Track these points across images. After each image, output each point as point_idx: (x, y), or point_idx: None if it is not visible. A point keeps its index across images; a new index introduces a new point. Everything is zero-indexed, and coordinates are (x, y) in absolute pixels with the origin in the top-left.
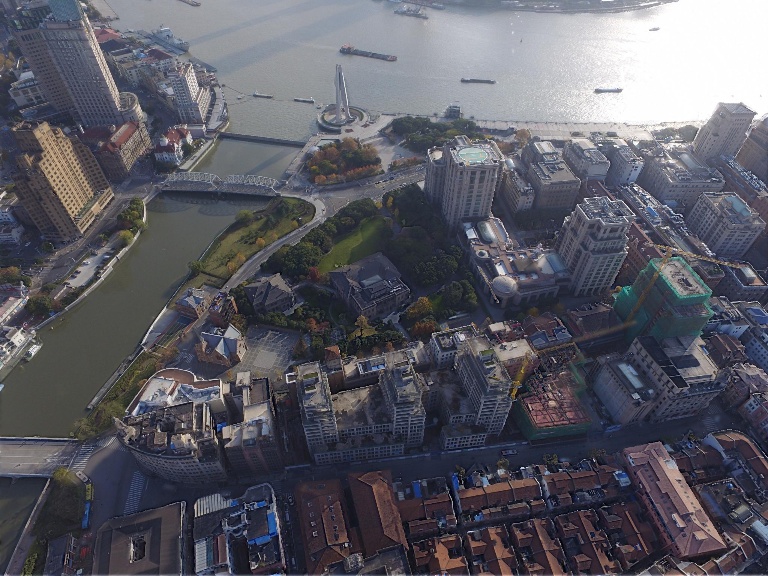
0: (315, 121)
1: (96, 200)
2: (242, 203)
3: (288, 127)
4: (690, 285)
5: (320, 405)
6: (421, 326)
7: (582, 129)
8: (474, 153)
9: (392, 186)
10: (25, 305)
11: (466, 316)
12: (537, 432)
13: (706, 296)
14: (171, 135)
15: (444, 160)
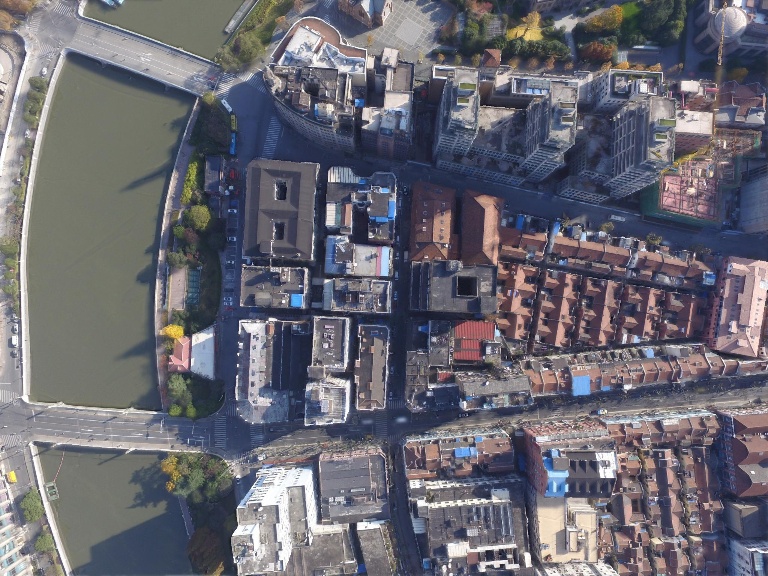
0: None
1: None
2: None
3: None
4: None
5: (467, 121)
6: (598, 48)
7: None
8: None
9: None
10: None
11: (655, 50)
12: (657, 212)
13: None
14: None
15: None
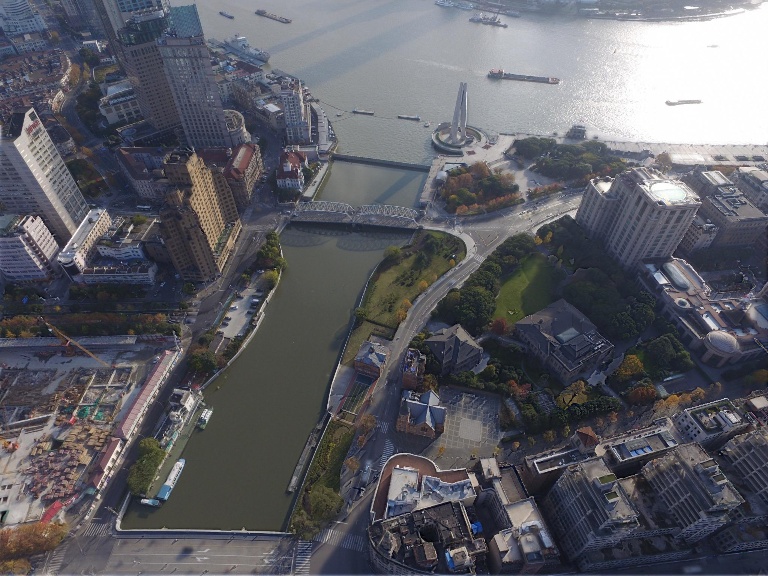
0: (430, 141)
1: (229, 234)
2: (376, 235)
3: (403, 148)
4: None
5: None
6: (644, 392)
7: (722, 152)
8: (669, 189)
9: (539, 217)
10: (188, 361)
11: (681, 377)
12: None
13: None
14: (291, 159)
15: (617, 193)
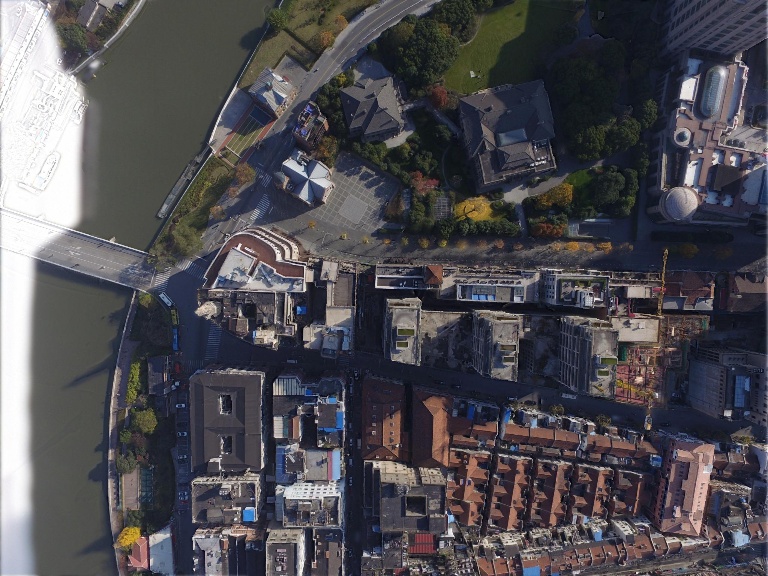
0: None
1: None
2: None
3: None
4: None
5: None
6: (547, 231)
7: None
8: None
9: None
10: (51, 32)
11: (607, 222)
12: None
13: None
14: None
15: None
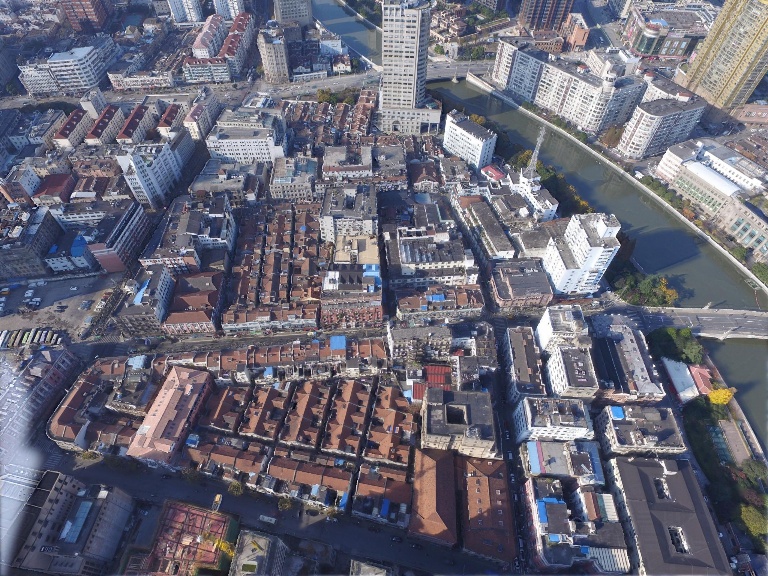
0: None
1: None
2: None
3: None
4: None
5: None
6: None
7: None
8: None
9: None
10: None
11: None
12: None
13: None
14: None
15: None
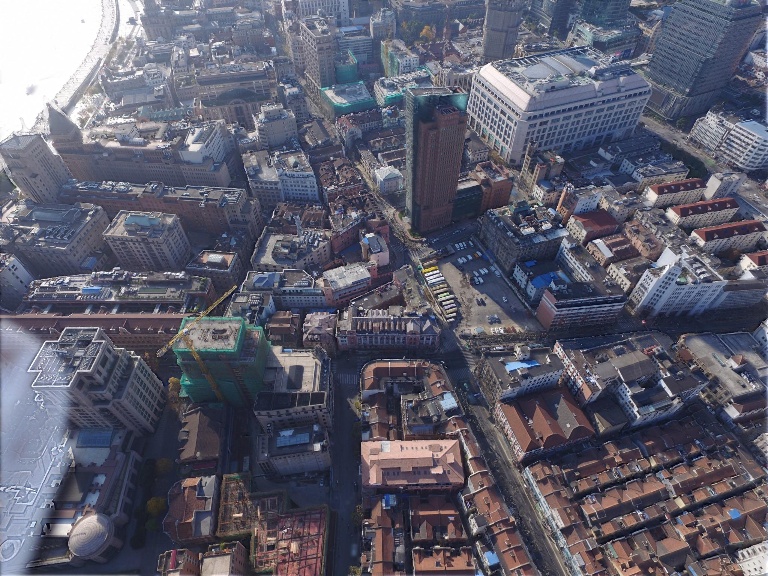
0: None
1: None
2: None
3: None
4: (224, 331)
5: None
6: None
7: None
8: None
9: None
10: None
11: None
12: None
13: (243, 325)
14: None
15: None
